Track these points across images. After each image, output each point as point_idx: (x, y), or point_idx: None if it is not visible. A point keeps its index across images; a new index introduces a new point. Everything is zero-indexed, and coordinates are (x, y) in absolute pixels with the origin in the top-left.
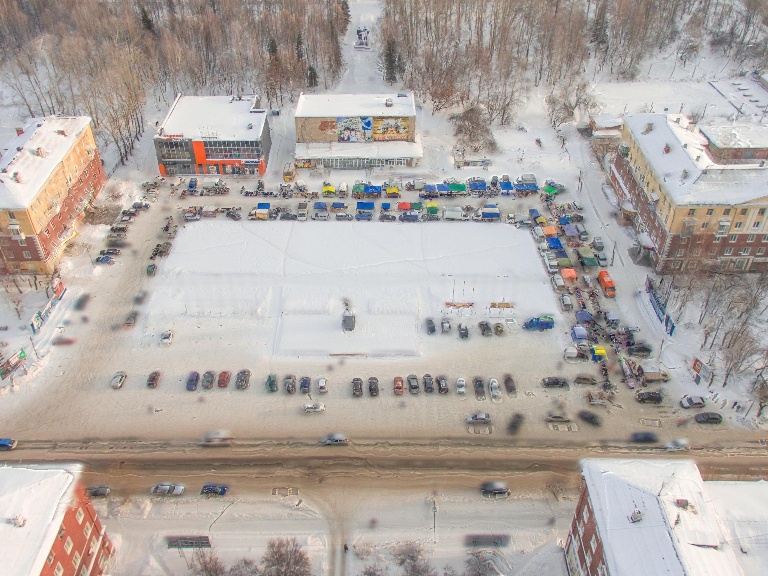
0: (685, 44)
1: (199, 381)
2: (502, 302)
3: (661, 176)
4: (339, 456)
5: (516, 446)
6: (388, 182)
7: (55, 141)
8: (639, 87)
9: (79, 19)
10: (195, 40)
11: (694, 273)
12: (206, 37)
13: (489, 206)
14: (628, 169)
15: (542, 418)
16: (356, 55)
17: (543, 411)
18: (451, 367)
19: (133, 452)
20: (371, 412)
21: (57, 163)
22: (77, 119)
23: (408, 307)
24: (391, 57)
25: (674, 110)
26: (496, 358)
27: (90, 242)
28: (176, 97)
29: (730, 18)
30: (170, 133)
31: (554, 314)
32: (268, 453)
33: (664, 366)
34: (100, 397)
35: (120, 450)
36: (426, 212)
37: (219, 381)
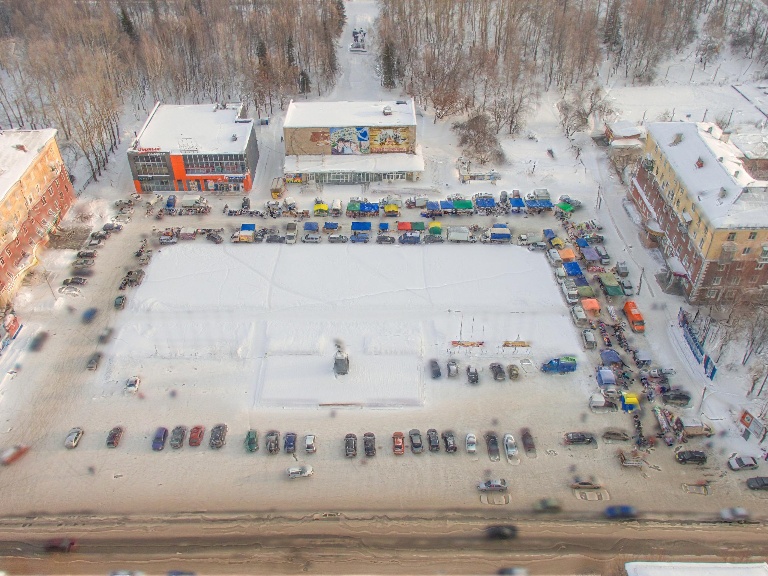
0: (705, 45)
1: (167, 438)
2: (516, 340)
3: (695, 194)
4: (328, 535)
5: (538, 520)
6: (386, 199)
7: (13, 157)
8: (657, 91)
9: (53, 22)
10: (178, 43)
11: (734, 305)
12: (190, 40)
13: (498, 226)
14: (653, 184)
15: (567, 484)
16: (352, 59)
17: (568, 475)
18: (459, 419)
19: (85, 530)
20: (366, 477)
21: (14, 182)
22: (40, 132)
23: (409, 346)
24: (389, 61)
25: (697, 117)
26: (511, 408)
27: (53, 270)
28: None
29: (751, 17)
30: (146, 146)
31: (576, 353)
32: (245, 531)
33: (706, 418)
34: (51, 459)
35: (70, 528)
36: (428, 233)
37: (190, 439)
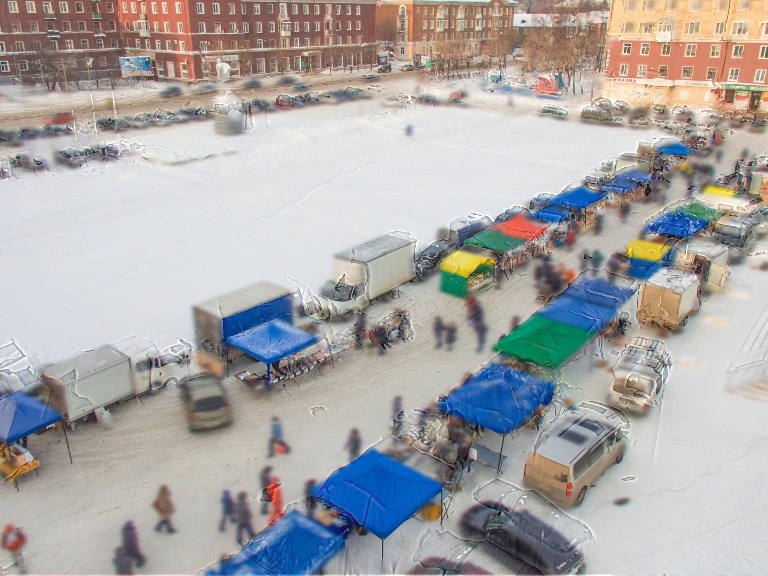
0: None
1: None
2: None
3: None
4: (123, 98)
5: None
6: None
7: None
8: None
9: None
10: None
11: None
12: None
13: None
14: None
15: None
16: None
17: None
18: (61, 145)
19: None
20: None
21: None
22: None
23: (201, 146)
24: None
25: None
26: None
27: None
28: None
29: None
30: None
31: None
32: None
33: None
34: None
35: None
36: None
37: None
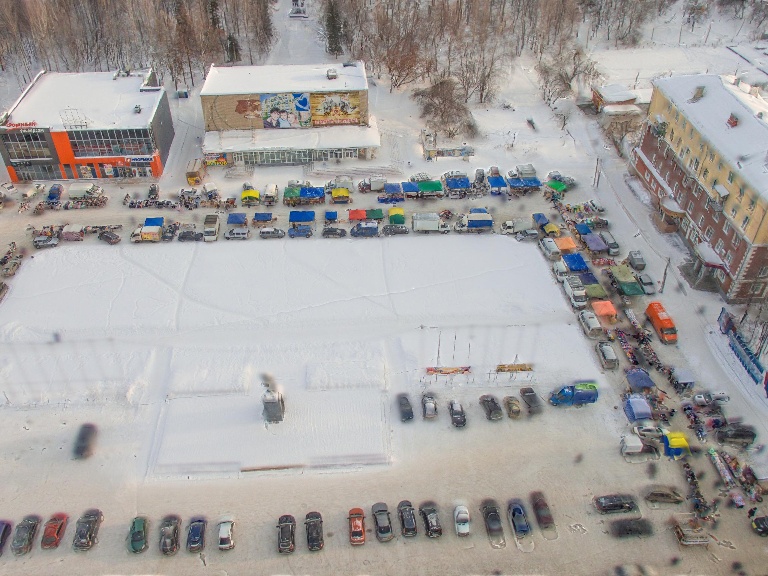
0: (693, 2)
1: (7, 539)
2: (514, 363)
3: (732, 160)
4: None
5: None
6: (334, 181)
7: None
8: (644, 54)
9: None
10: (74, 2)
11: None
12: None
13: (476, 211)
14: (667, 153)
15: None
16: (292, 25)
17: (605, 564)
18: (443, 483)
19: None
20: None
21: None
22: None
23: (368, 376)
24: (334, 21)
25: None
26: (514, 461)
27: None
28: None
29: None
30: (19, 121)
31: (593, 376)
32: None
33: None
34: None
35: None
36: (388, 222)
37: (42, 538)
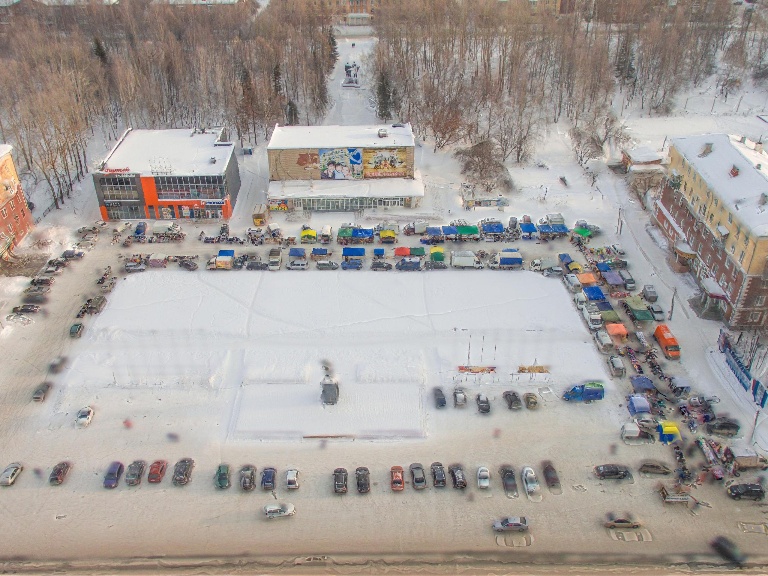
0: (725, 75)
1: (122, 475)
2: (533, 365)
3: (731, 203)
4: None
5: (566, 564)
6: (381, 225)
7: None
8: (675, 122)
9: (19, 49)
10: (154, 71)
11: None
12: (167, 68)
13: (508, 250)
14: (681, 202)
15: (599, 522)
16: (344, 93)
17: (600, 512)
18: (468, 452)
19: None
20: (359, 516)
21: None
22: None
23: (408, 373)
24: (384, 89)
25: None
26: (529, 439)
27: (2, 298)
28: (126, 130)
29: None
30: (114, 168)
31: (602, 381)
32: None
33: (760, 448)
34: None
35: None
36: (429, 259)
37: (149, 474)
